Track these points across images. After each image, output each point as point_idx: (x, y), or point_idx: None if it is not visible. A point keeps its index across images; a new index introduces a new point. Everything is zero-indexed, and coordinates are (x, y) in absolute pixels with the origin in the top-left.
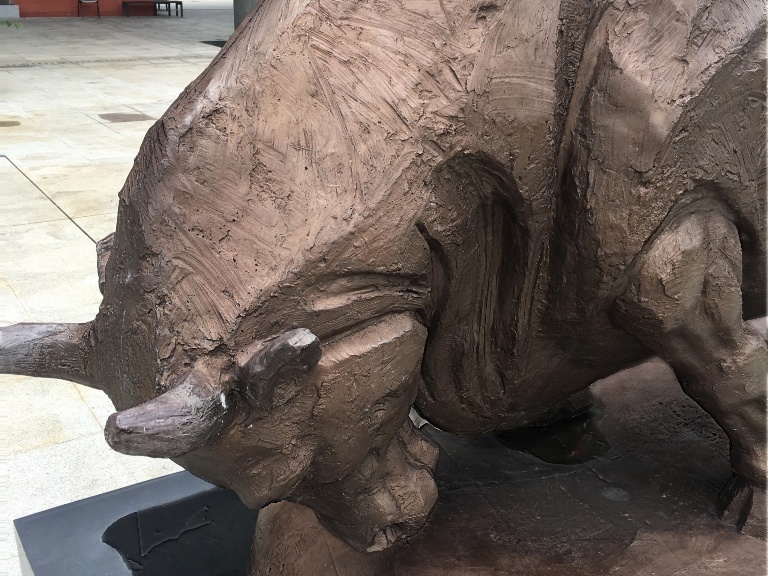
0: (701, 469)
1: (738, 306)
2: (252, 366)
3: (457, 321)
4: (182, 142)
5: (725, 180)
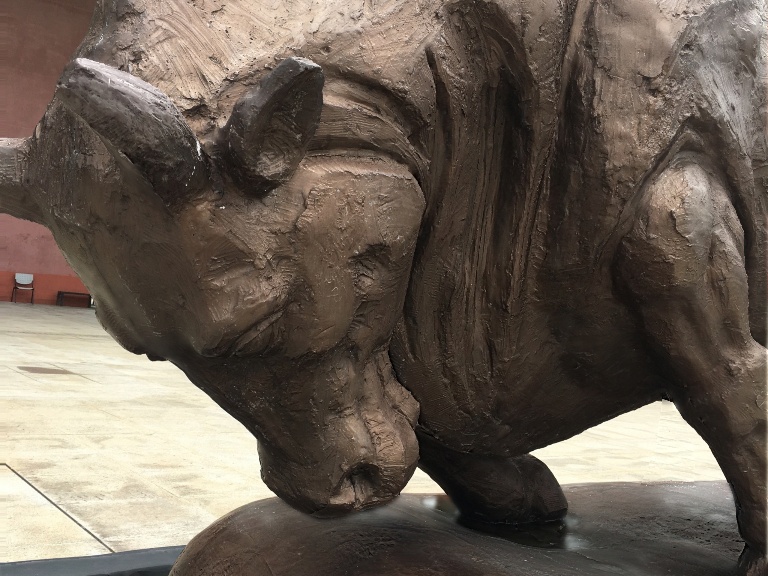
0: (701, 561)
1: (745, 288)
2: (241, 98)
3: (450, 240)
4: None
5: (726, 131)
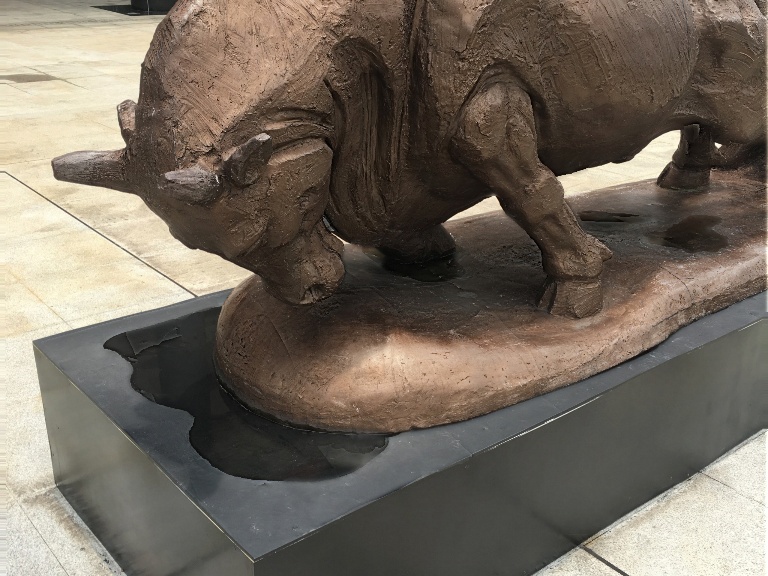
0: (527, 281)
1: (532, 147)
2: (234, 156)
3: (352, 154)
4: (183, 30)
5: (515, 61)
